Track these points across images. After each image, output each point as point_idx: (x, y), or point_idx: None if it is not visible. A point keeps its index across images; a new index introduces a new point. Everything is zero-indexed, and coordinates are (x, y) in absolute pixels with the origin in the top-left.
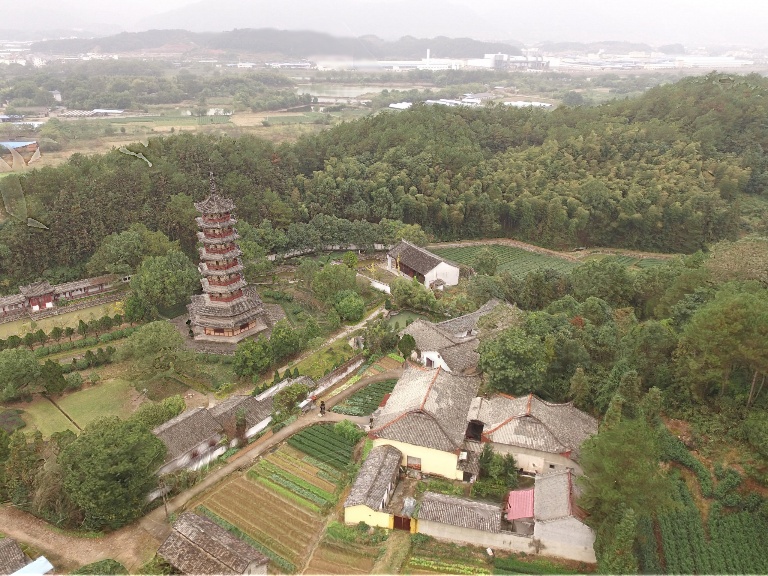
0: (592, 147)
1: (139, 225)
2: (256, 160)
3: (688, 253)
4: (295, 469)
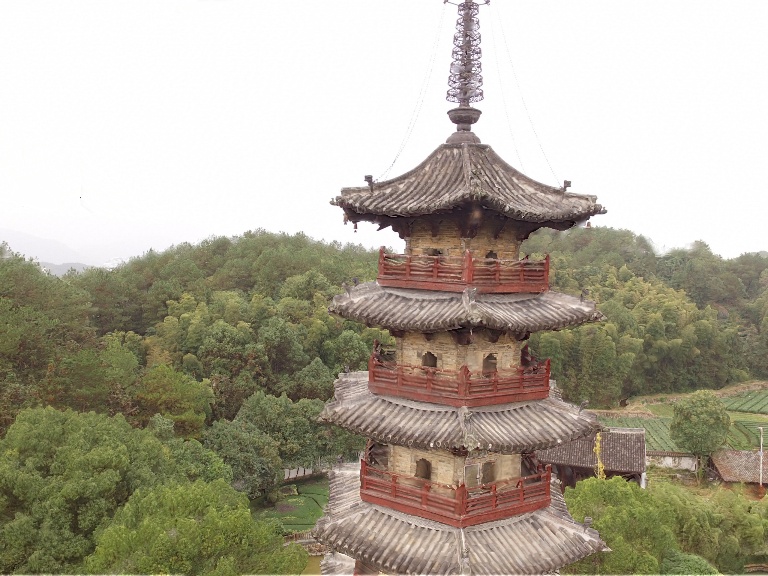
0: None
1: None
2: (45, 280)
3: (715, 388)
4: None
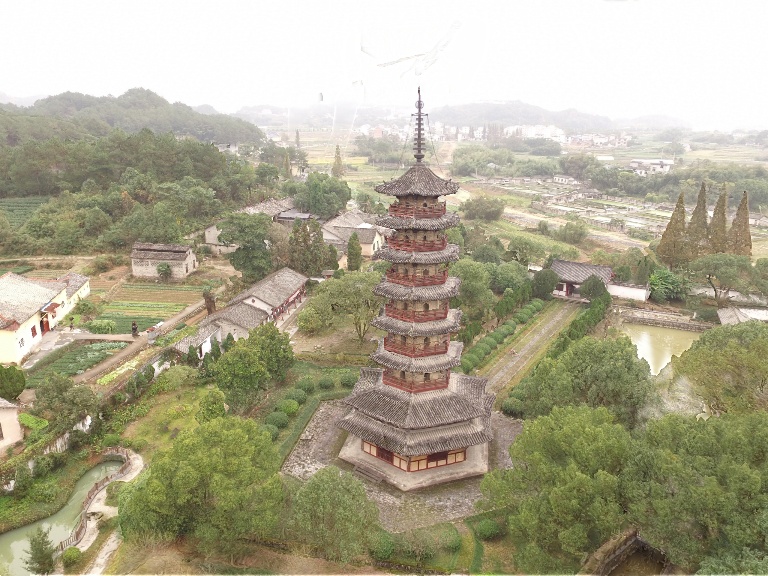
0: None
1: None
2: None
3: None
4: (147, 311)
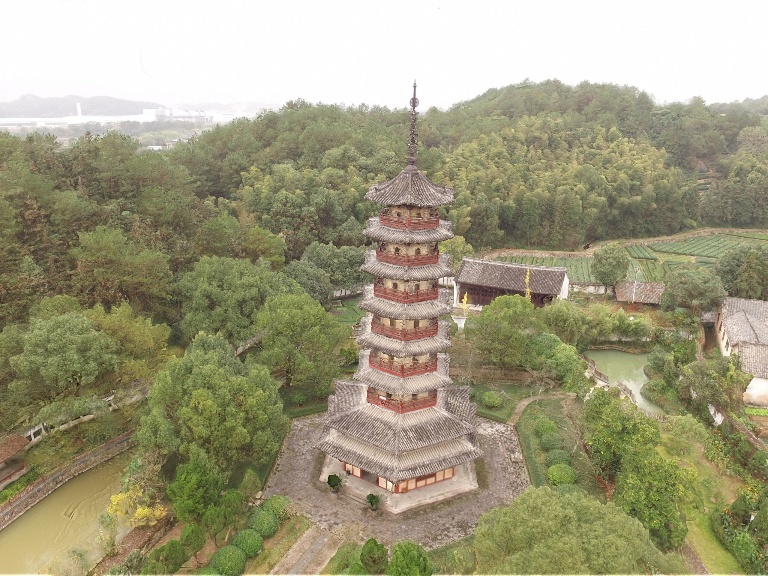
0: (538, 136)
1: (61, 300)
2: (173, 168)
3: (669, 234)
4: None
